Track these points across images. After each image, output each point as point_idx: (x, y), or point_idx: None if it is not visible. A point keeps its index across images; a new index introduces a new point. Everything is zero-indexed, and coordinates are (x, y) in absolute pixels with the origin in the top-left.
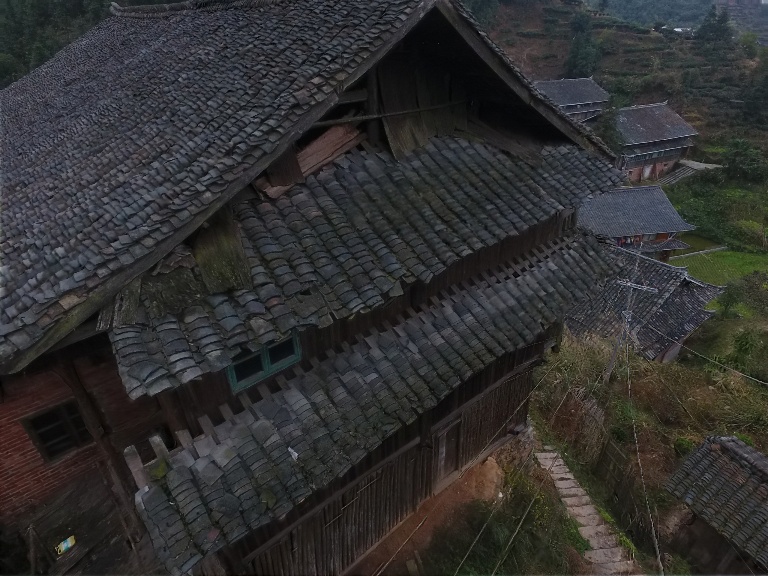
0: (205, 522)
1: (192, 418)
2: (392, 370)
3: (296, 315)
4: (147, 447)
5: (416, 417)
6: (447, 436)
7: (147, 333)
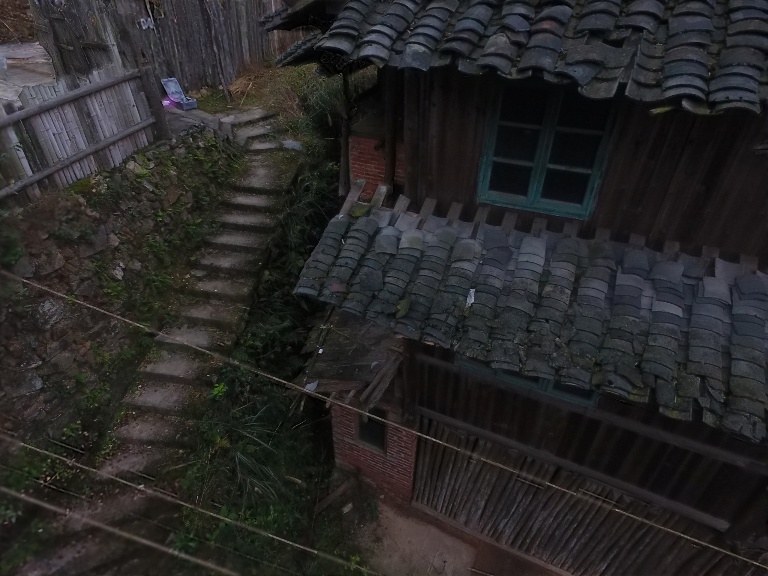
0: (344, 274)
1: (423, 194)
2: (720, 328)
3: (563, 59)
4: (373, 190)
5: (689, 418)
6: None
7: (386, 6)
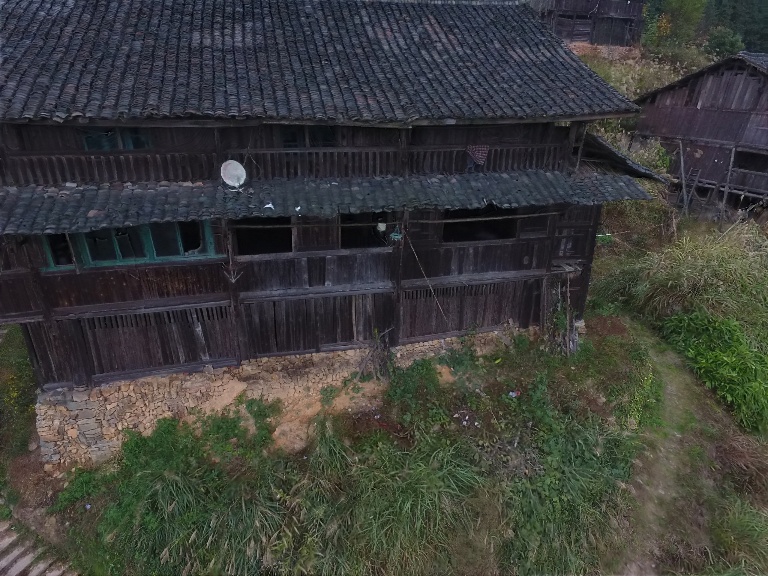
0: None
1: None
2: None
3: None
4: None
5: None
6: None
7: None
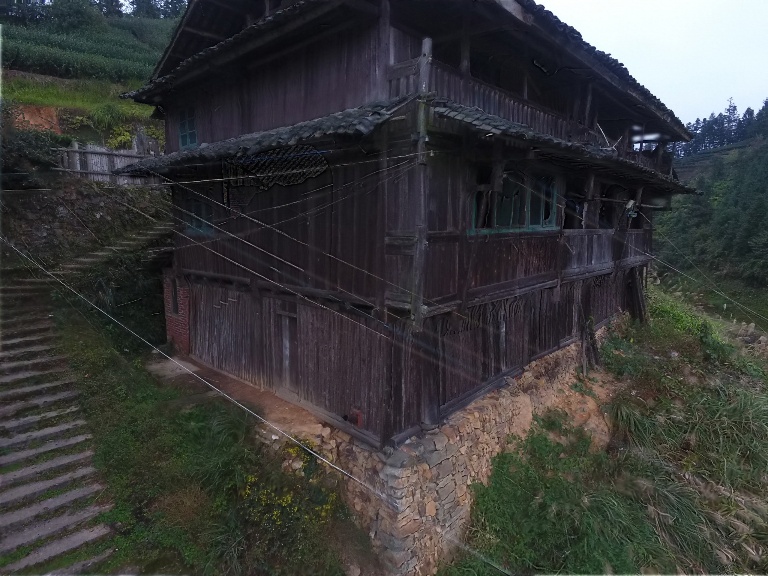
0: None
1: None
2: None
3: None
4: None
5: None
6: (290, 330)
7: None
